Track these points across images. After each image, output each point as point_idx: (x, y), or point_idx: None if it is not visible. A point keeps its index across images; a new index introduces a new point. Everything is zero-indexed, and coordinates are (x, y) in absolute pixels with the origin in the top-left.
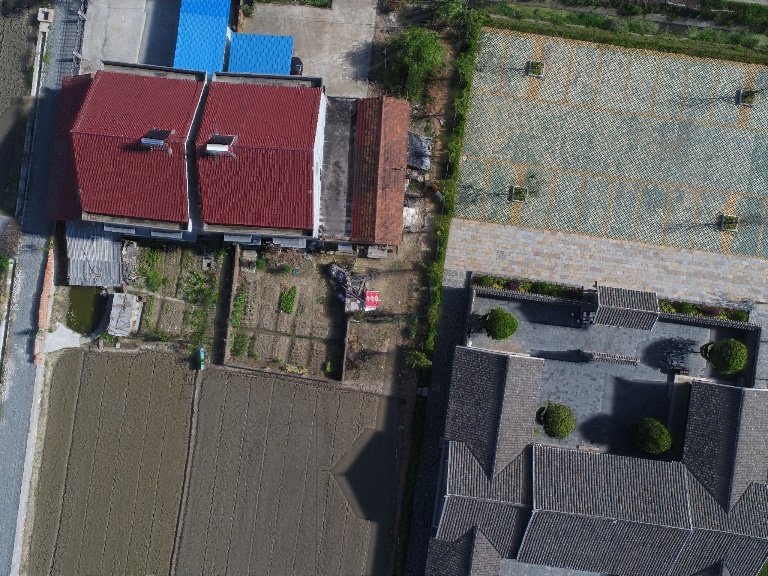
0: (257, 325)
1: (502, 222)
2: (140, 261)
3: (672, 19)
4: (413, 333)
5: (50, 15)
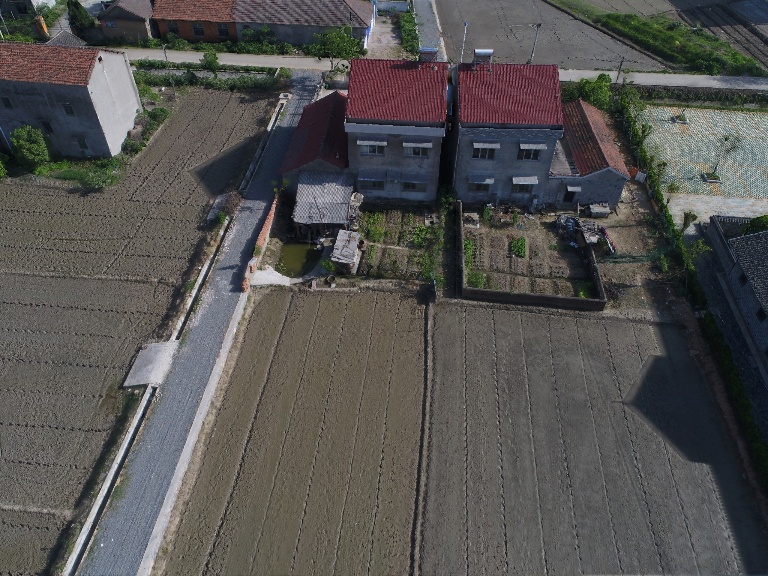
0: (489, 267)
1: (707, 194)
2: None
3: (765, 106)
4: (665, 264)
5: (289, 96)
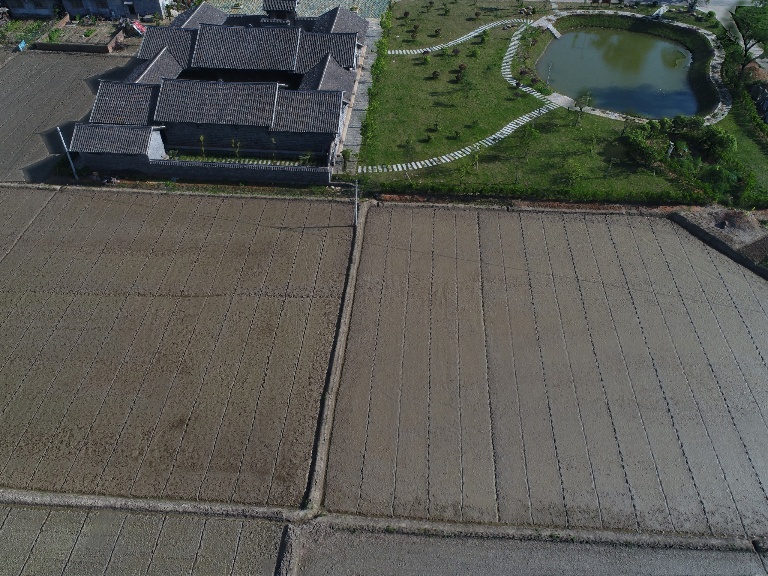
0: (65, 40)
1: None
2: None
3: None
4: None
5: None
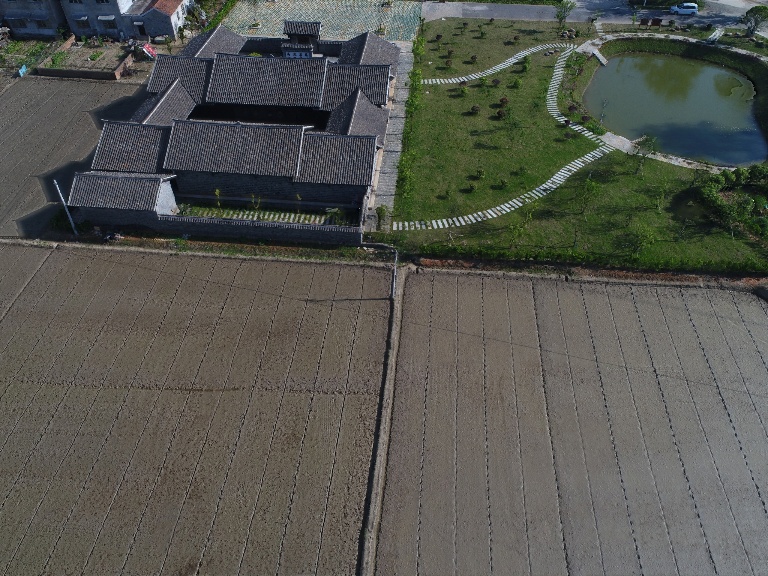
0: None
1: None
2: (7, 45)
3: None
4: None
5: None
